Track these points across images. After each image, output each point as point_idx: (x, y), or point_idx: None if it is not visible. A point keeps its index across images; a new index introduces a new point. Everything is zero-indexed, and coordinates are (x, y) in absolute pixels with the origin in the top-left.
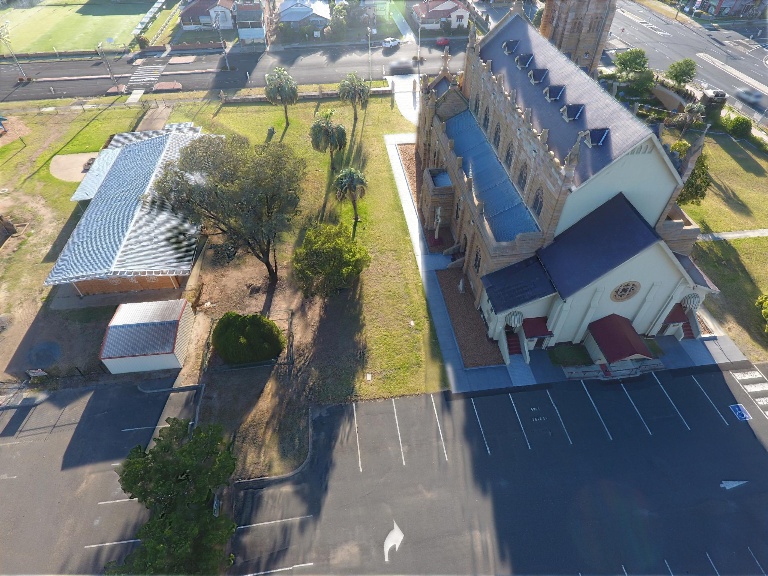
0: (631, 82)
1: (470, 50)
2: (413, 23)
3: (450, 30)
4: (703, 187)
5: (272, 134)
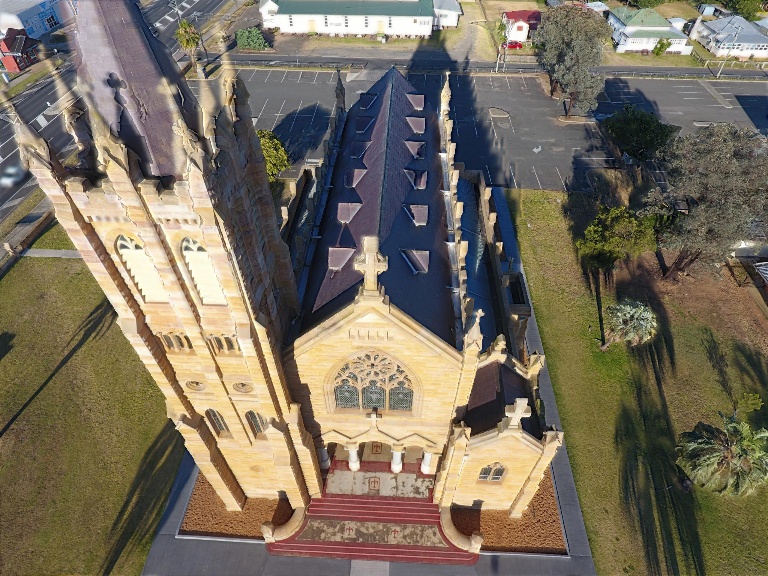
0: None
1: None
2: None
3: None
4: None
5: None
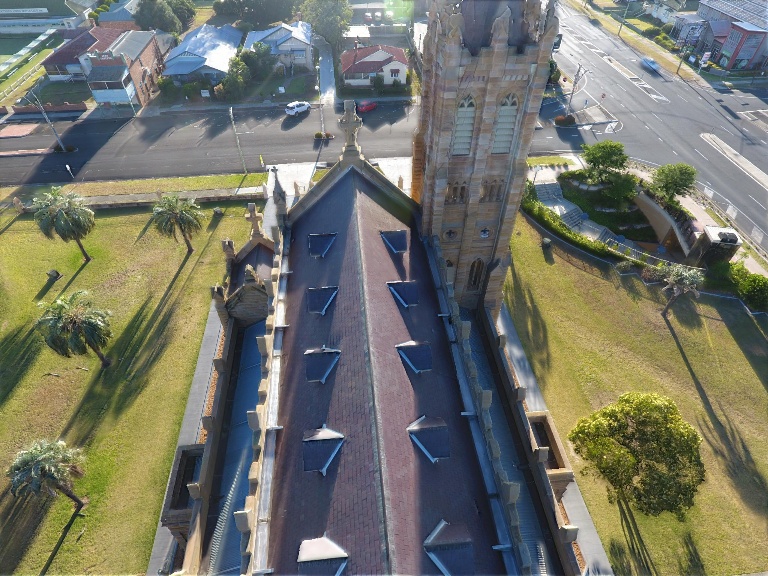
0: (605, 185)
1: None
2: (338, 76)
3: (381, 88)
4: (689, 487)
5: (54, 281)
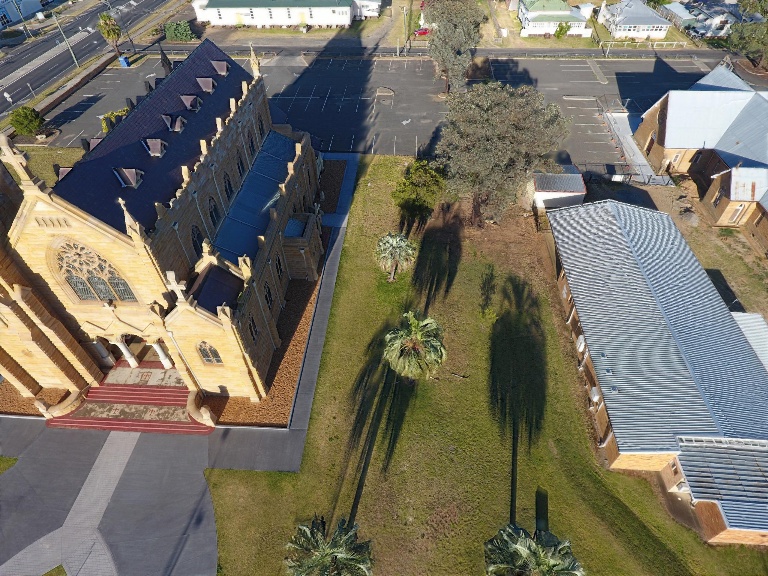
0: None
1: (154, 236)
2: None
3: None
4: None
5: (539, 531)
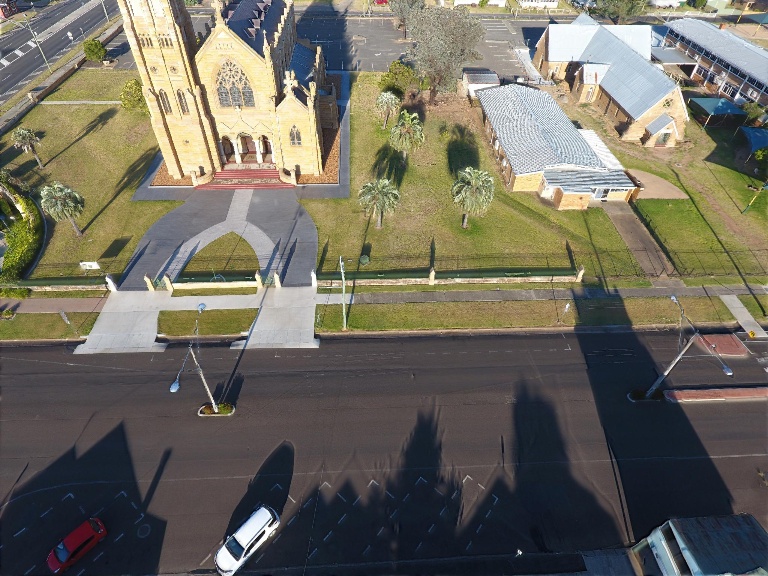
0: None
1: None
2: None
3: None
4: None
5: None
